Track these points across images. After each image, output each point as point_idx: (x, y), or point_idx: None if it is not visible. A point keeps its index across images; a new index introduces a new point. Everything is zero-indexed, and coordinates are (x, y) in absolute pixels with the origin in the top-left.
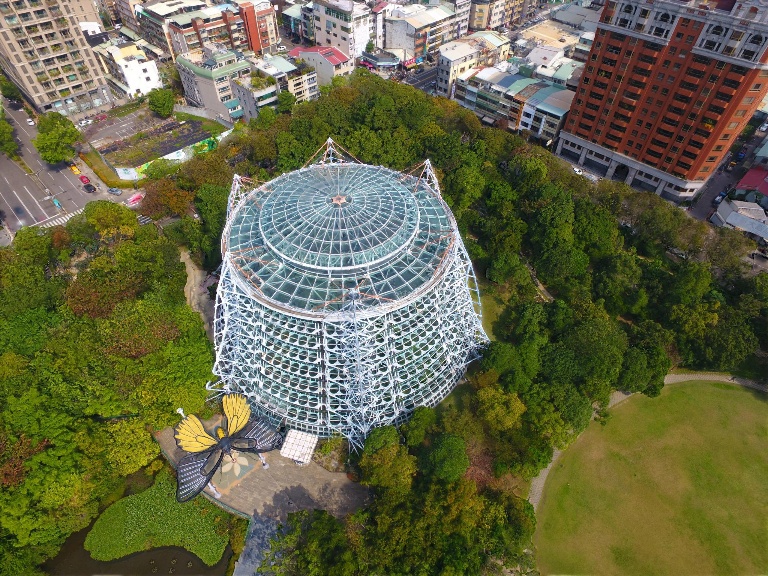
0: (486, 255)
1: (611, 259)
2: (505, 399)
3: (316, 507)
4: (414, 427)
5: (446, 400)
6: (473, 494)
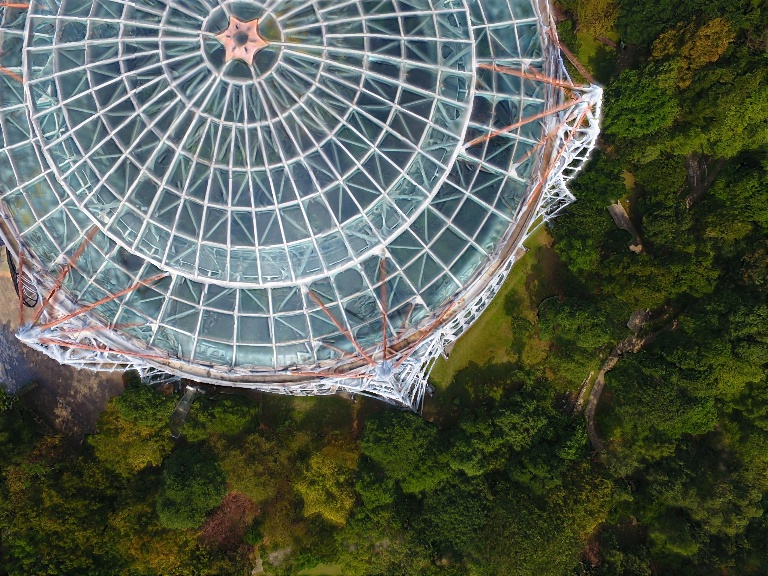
0: (592, 266)
1: (736, 465)
2: (333, 491)
3: (68, 374)
4: (201, 421)
5: (305, 397)
6: (175, 550)
